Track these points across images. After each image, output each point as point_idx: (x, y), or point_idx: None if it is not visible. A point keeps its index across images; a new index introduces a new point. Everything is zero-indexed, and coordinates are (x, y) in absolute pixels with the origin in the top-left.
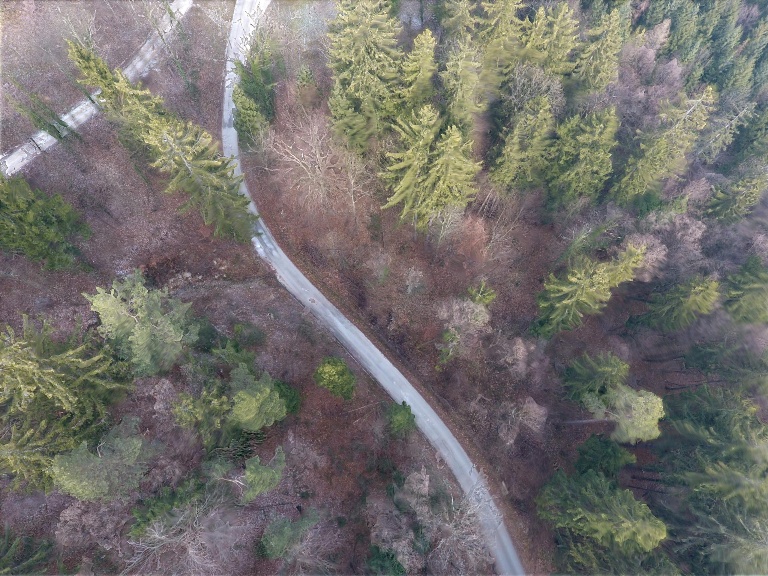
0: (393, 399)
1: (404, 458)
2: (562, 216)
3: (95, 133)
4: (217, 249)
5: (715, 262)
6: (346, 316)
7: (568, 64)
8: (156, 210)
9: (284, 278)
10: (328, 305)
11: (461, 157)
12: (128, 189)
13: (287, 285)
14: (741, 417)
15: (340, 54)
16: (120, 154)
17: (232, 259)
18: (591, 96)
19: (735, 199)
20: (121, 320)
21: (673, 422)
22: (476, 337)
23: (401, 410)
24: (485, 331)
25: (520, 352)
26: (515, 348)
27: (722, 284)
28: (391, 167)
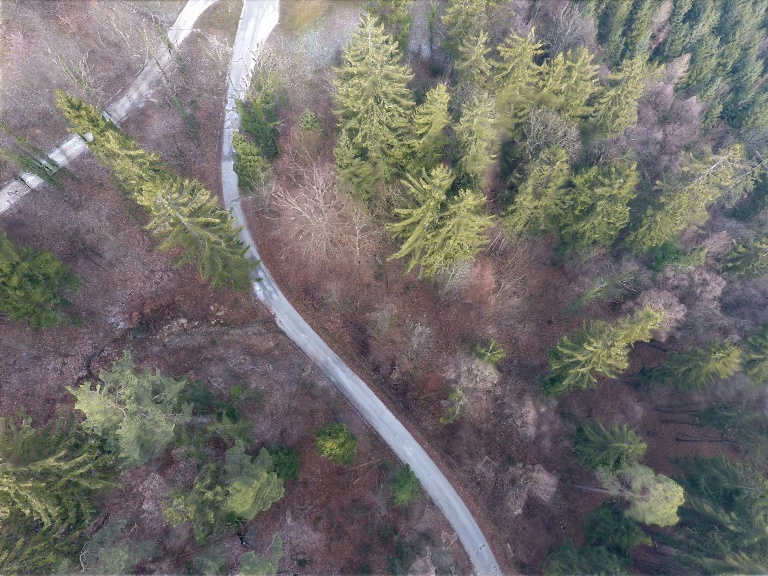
0: (395, 454)
1: (406, 520)
2: (574, 260)
3: (88, 169)
4: (214, 293)
5: (735, 321)
6: (348, 365)
7: (586, 108)
8: (151, 250)
9: (284, 323)
10: (329, 353)
11: (474, 218)
12: (122, 228)
13: (287, 331)
14: (764, 504)
15: (347, 102)
16: (114, 191)
17: (230, 304)
18: (608, 140)
19: (757, 255)
20: (108, 415)
21: (690, 498)
22: (484, 399)
23: (405, 480)
24: (494, 392)
25: (530, 416)
26: (525, 411)
27: (742, 346)
28: (399, 224)
